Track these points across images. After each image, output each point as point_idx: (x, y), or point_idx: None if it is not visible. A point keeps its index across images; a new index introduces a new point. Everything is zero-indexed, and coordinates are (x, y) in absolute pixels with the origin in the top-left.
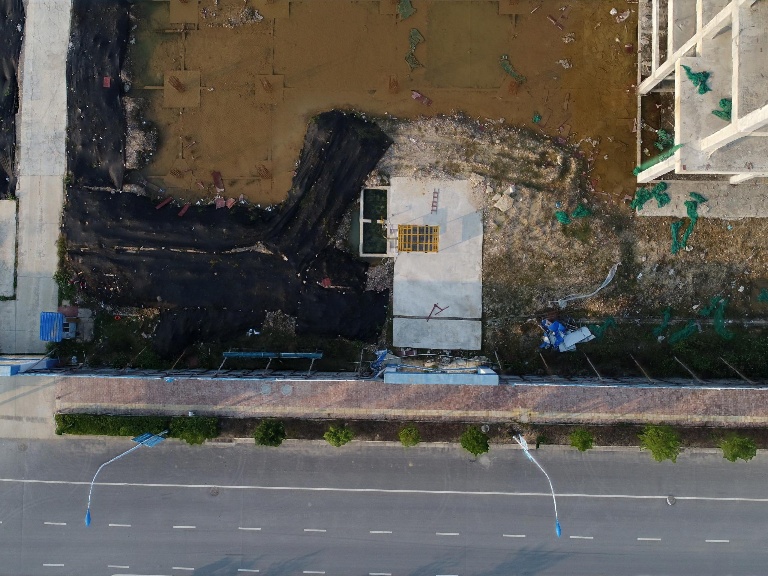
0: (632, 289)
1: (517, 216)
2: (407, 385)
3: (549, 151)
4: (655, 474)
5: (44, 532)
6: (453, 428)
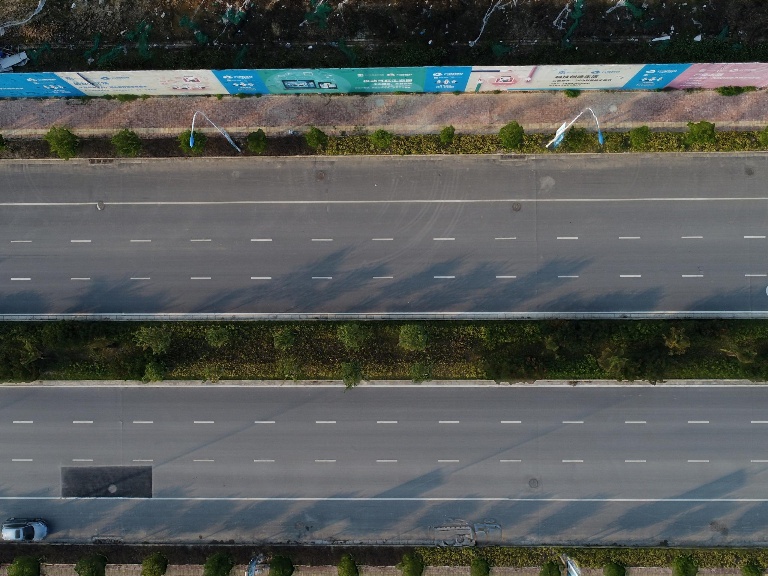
0: (66, 18)
1: None
2: None
3: None
4: (87, 183)
5: None
6: None
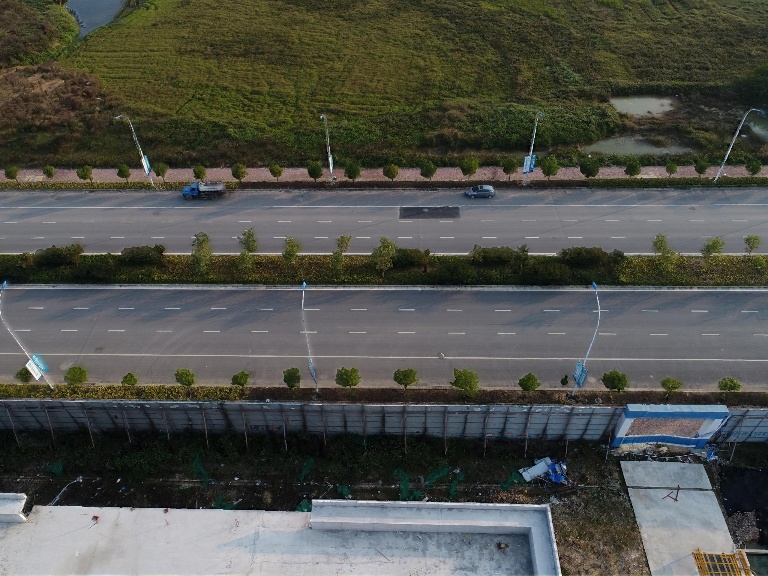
0: None
1: None
2: (678, 432)
3: None
4: None
5: None
6: (626, 401)
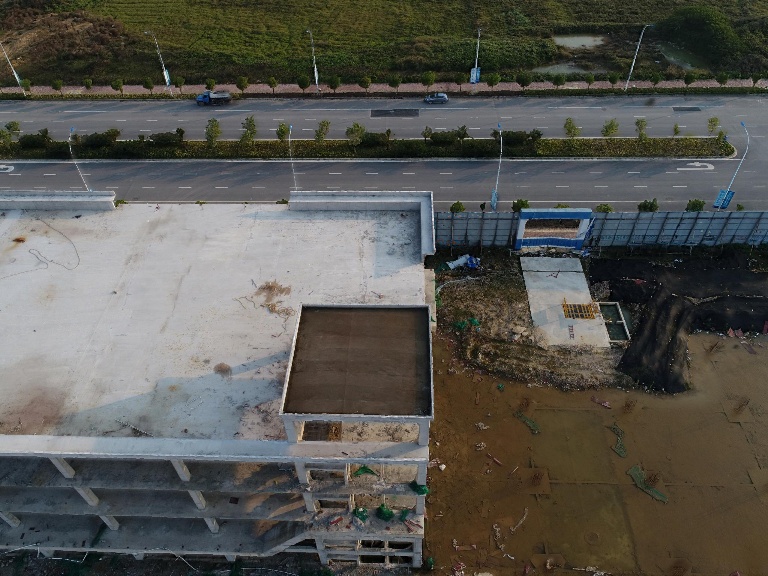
0: None
1: (508, 324)
2: None
3: (489, 363)
4: None
5: (764, 183)
6: None
